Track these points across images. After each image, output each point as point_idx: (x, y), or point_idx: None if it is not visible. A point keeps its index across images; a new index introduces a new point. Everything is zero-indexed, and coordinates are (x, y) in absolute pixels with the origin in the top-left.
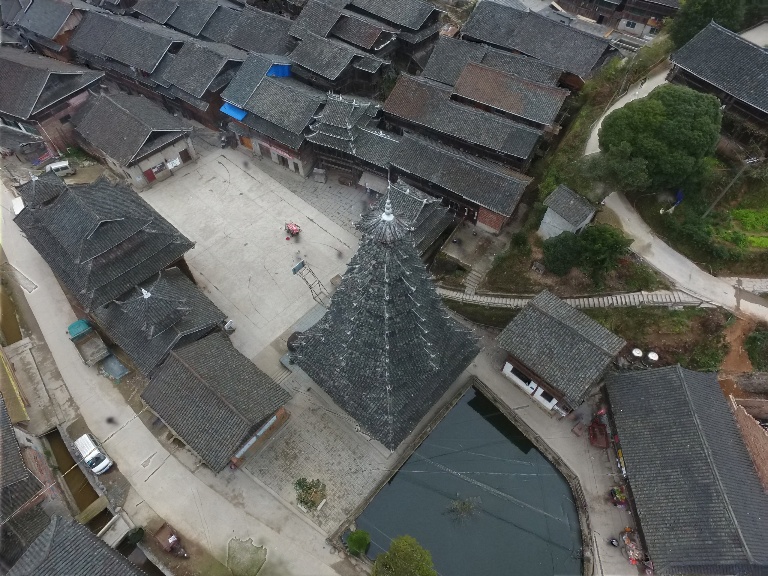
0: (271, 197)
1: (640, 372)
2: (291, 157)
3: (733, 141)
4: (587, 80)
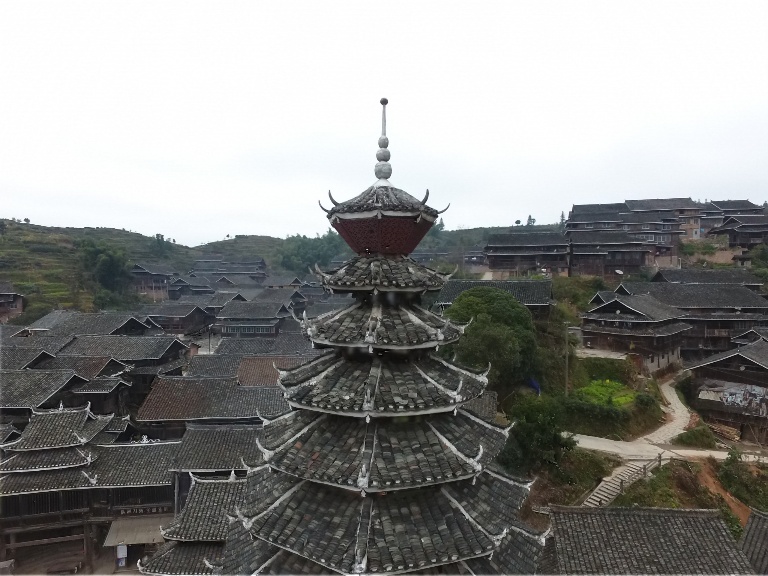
0: None
1: None
2: None
3: (542, 316)
4: None
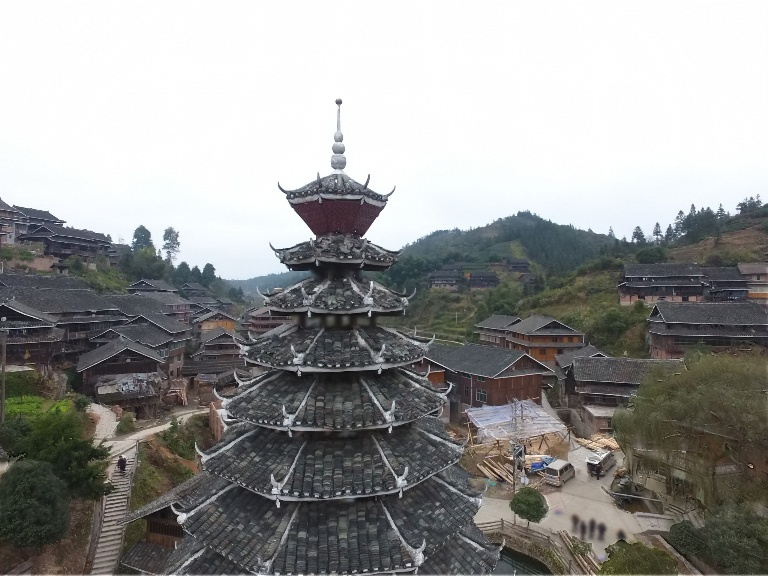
0: None
1: None
2: None
3: None
4: None
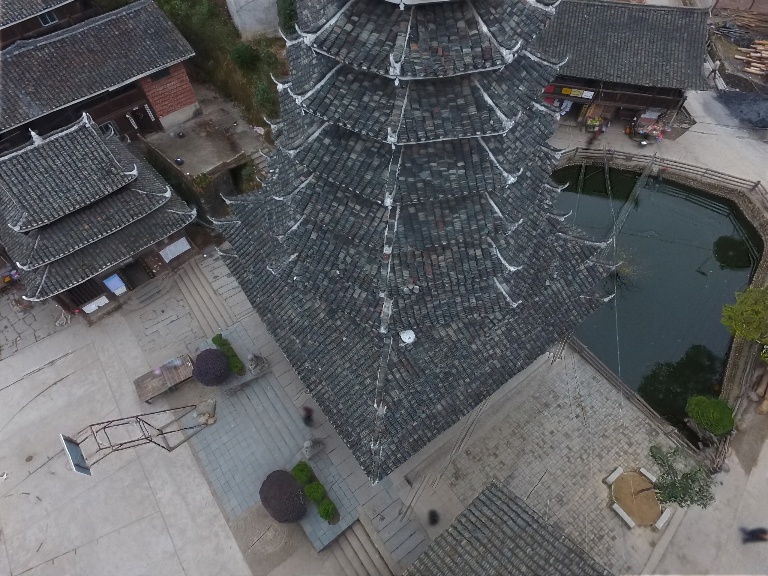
0: None
1: None
2: None
3: None
4: None
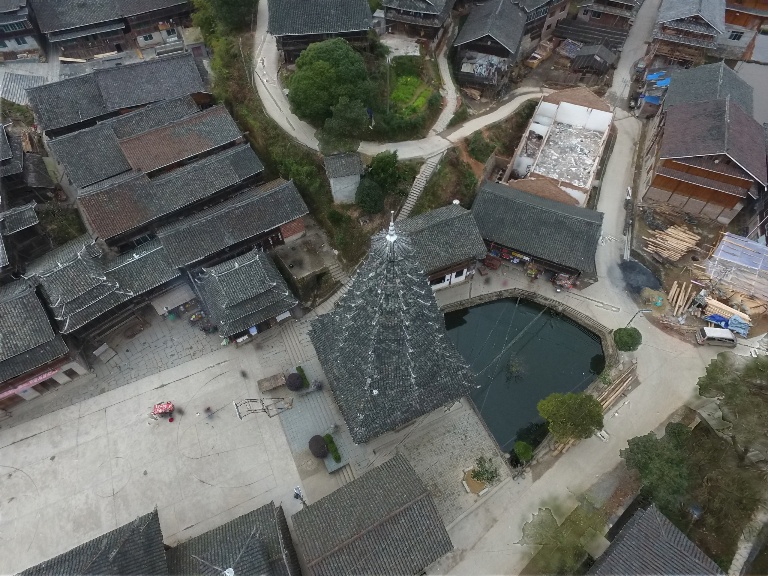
0: (89, 421)
1: (474, 210)
2: (56, 370)
3: (370, 57)
4: (213, 90)
